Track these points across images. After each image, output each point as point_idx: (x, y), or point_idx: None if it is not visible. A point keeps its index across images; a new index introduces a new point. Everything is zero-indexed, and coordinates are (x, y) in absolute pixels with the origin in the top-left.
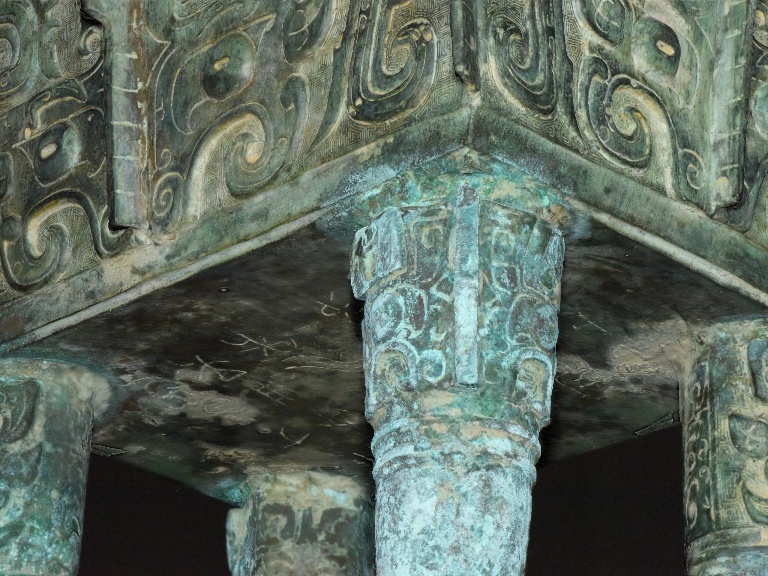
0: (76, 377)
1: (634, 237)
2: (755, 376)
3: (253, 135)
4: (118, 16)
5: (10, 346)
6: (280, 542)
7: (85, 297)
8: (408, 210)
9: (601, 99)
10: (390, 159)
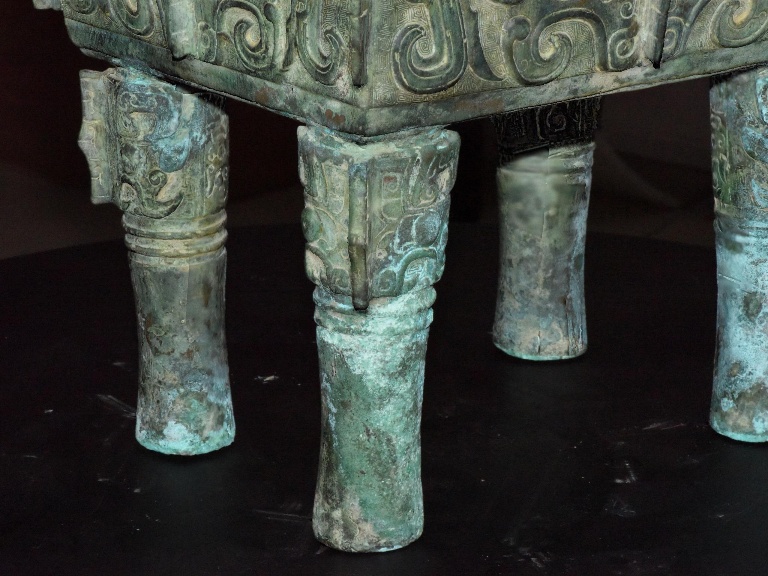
0: None
1: None
2: None
3: None
4: None
5: None
6: None
7: None
8: None
9: None
10: None
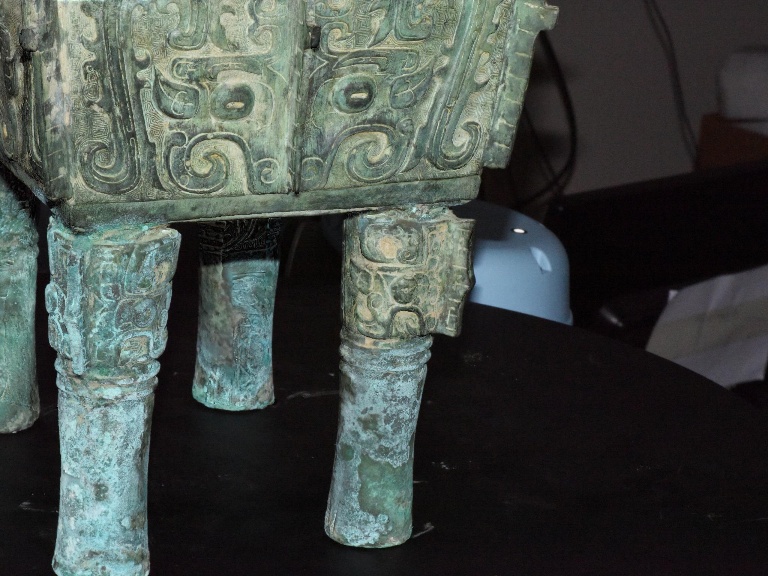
0: None
1: (227, 219)
2: (360, 243)
3: None
4: None
5: None
6: None
7: None
8: (57, 238)
9: (181, 158)
10: None
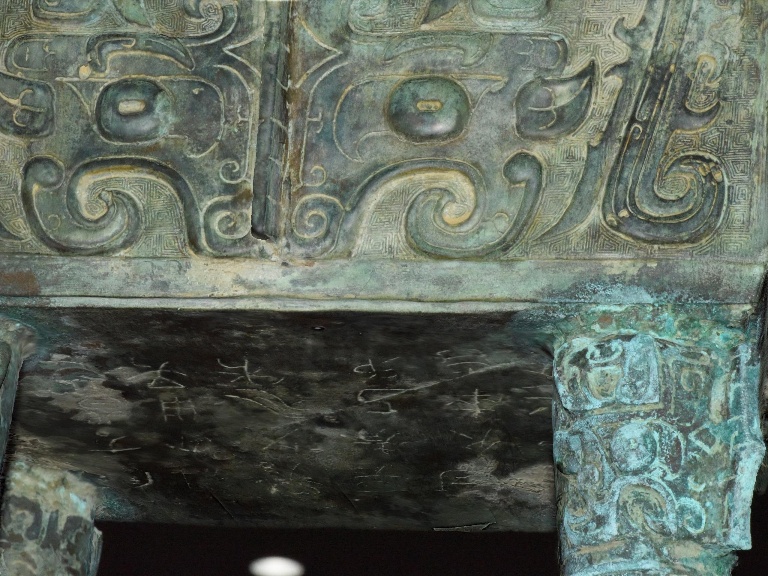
0: (23, 345)
1: None
2: None
3: (454, 194)
4: (285, 1)
5: (3, 300)
6: (24, 541)
7: (152, 285)
8: (666, 344)
9: None
10: (649, 284)
